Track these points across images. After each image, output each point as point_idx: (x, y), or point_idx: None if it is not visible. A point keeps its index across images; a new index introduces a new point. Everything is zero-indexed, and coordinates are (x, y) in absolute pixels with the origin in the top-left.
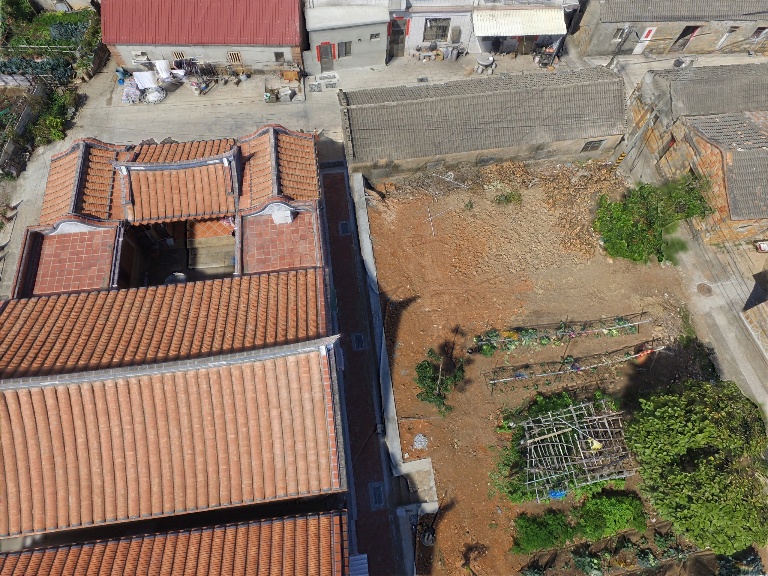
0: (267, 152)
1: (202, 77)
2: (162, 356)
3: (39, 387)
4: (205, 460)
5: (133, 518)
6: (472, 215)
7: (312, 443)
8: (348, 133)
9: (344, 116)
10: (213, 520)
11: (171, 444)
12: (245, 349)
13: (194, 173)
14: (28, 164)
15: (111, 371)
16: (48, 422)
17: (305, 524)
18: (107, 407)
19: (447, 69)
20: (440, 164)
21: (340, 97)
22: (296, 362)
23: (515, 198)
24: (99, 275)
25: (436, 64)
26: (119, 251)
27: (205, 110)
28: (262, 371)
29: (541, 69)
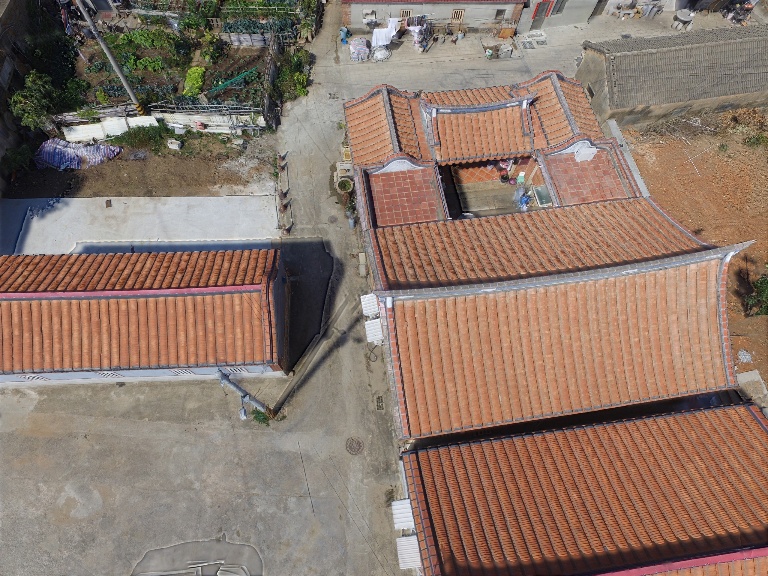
0: (552, 96)
1: (422, 36)
2: (564, 269)
3: (475, 295)
4: (612, 362)
5: (558, 414)
6: (727, 156)
7: (707, 345)
8: (614, 79)
9: (611, 63)
10: (626, 415)
11: (582, 348)
12: (640, 261)
13: (492, 116)
14: (281, 118)
15: (542, 279)
16: (478, 328)
17: (725, 413)
18: (527, 314)
19: (646, 26)
20: (685, 110)
21: (597, 46)
22: (696, 270)
23: (764, 140)
24: (432, 209)
25: (634, 22)
26: (441, 188)
27: (432, 67)
28: (664, 279)
29: (735, 25)
